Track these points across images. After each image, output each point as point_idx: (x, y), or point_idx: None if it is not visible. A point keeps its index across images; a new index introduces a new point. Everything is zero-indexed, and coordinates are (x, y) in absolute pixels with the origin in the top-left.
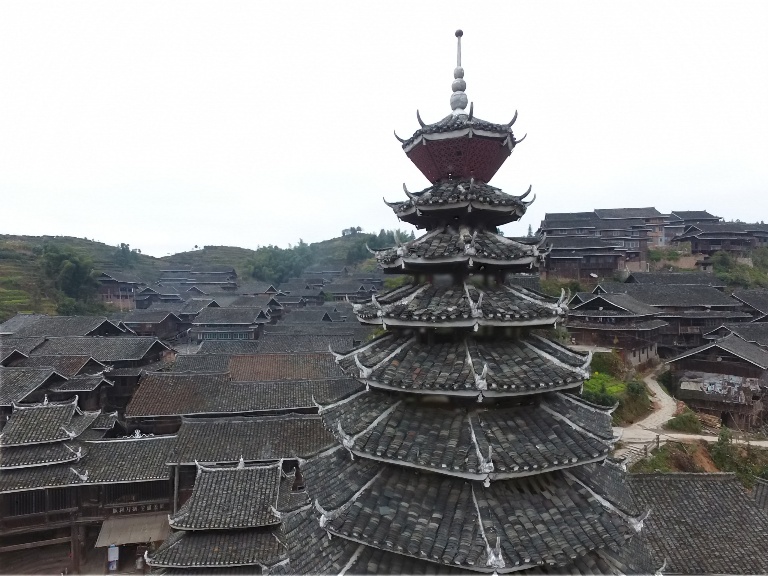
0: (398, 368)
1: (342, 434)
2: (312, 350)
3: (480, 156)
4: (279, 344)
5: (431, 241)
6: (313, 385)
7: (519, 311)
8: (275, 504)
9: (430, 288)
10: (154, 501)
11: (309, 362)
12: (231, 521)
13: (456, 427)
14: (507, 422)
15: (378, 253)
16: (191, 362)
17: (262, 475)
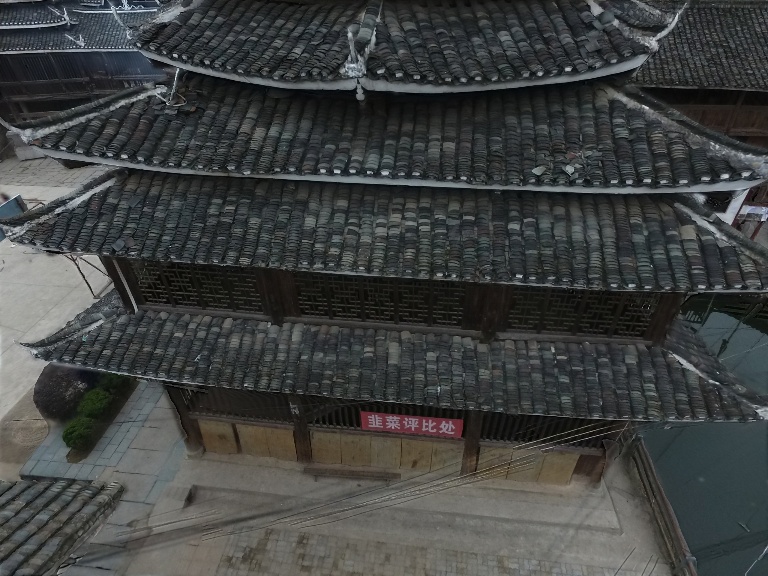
0: None
1: None
2: None
3: None
4: None
5: None
6: None
7: None
8: None
9: None
10: (160, 75)
11: None
12: None
13: None
14: None
15: None
16: None
17: None
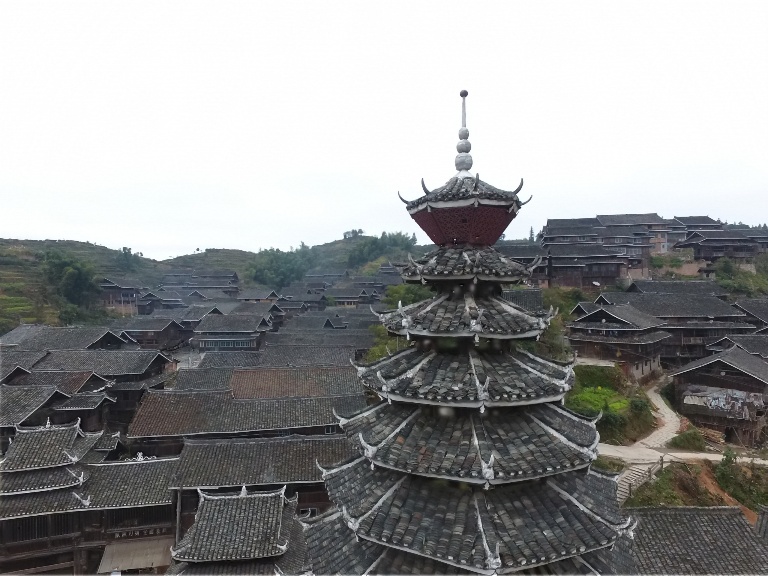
0: (403, 445)
1: (347, 517)
2: (314, 363)
3: (485, 223)
4: (281, 356)
5: (436, 310)
6: (315, 403)
7: (526, 389)
8: (278, 534)
9: (435, 358)
10: (156, 525)
11: (311, 377)
12: (234, 552)
13: (462, 510)
14: (514, 503)
15: (382, 316)
16: (193, 376)
17: (265, 503)
